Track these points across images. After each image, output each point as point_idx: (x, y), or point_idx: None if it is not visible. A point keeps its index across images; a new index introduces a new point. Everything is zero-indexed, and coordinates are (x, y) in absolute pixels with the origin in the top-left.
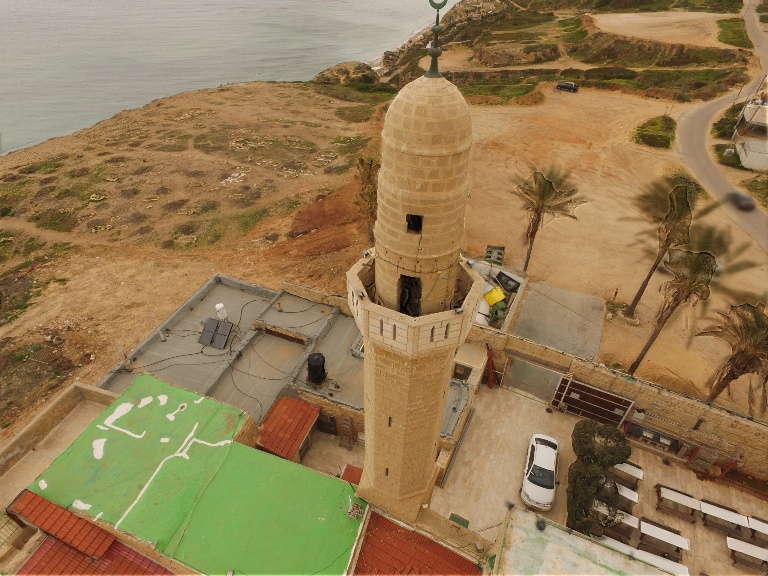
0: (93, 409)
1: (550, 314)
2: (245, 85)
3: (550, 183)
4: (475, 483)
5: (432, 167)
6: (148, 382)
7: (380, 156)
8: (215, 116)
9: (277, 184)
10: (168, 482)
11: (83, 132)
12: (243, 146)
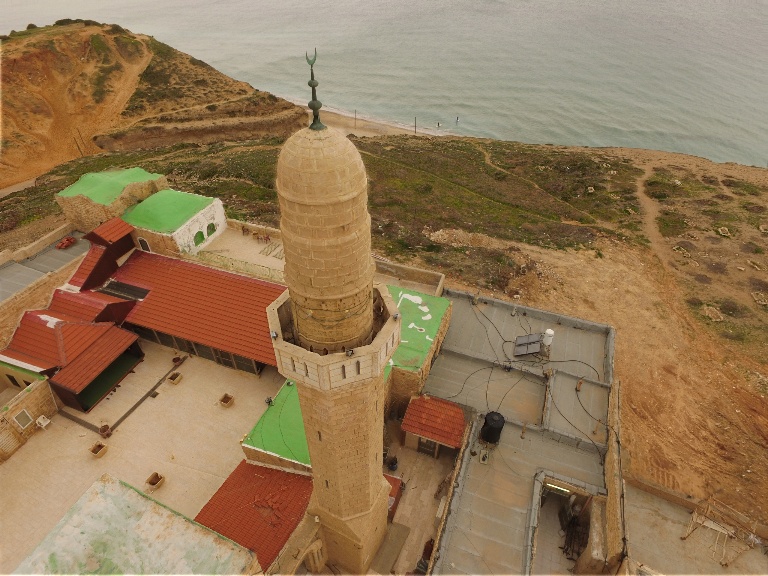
0: (432, 294)
1: None
2: None
3: None
4: None
5: None
6: (442, 305)
7: None
8: None
9: None
10: None
11: None
12: None
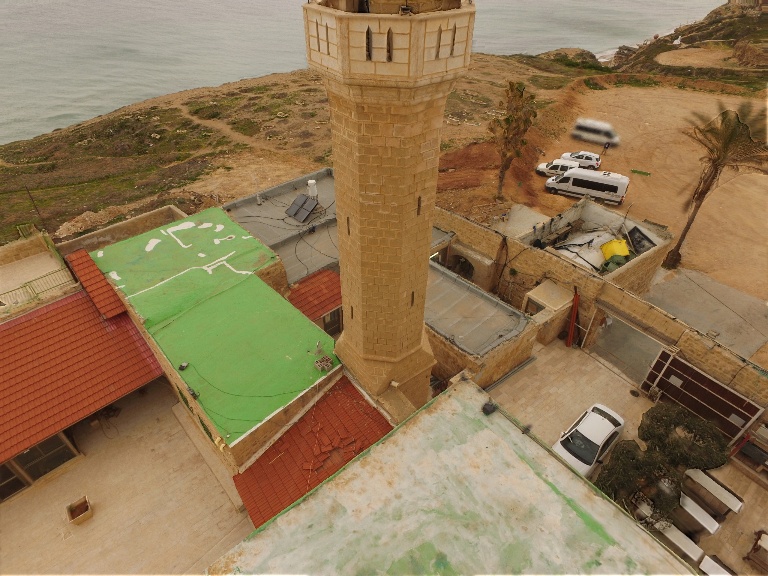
0: None
1: (694, 303)
2: None
3: (745, 126)
4: None
5: None
6: (216, 213)
7: (557, 120)
8: None
9: None
10: (183, 283)
11: (298, 71)
12: None
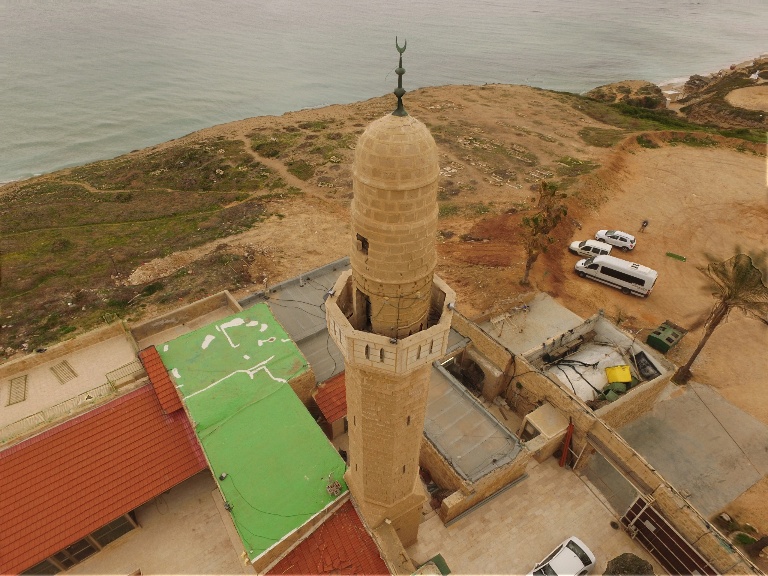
0: (229, 314)
1: (695, 427)
2: (508, 87)
3: (757, 273)
4: (480, 543)
5: (373, 197)
6: (263, 310)
7: (600, 187)
8: (461, 111)
9: (479, 187)
10: (229, 387)
11: (356, 104)
12: (468, 144)
